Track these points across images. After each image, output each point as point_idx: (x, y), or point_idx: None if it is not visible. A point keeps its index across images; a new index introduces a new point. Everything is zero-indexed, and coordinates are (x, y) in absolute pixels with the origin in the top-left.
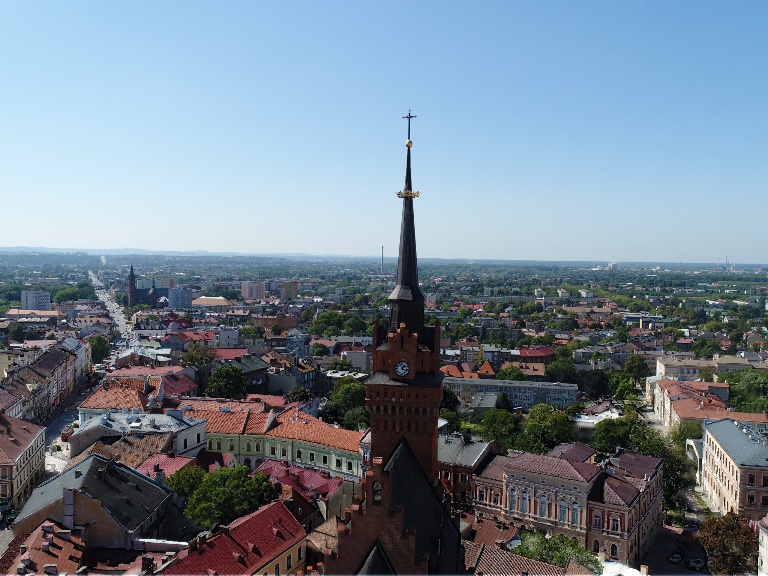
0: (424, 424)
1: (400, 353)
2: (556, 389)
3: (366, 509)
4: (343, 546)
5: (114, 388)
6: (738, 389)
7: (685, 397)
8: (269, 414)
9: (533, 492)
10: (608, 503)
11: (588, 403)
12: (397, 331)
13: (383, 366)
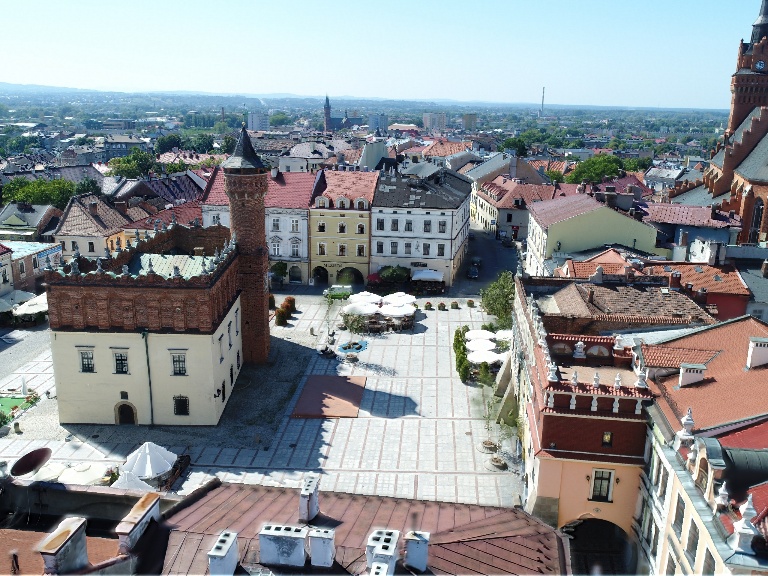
0: None
1: (760, 55)
2: None
3: None
4: (754, 127)
5: (448, 143)
6: None
7: None
8: (565, 162)
9: None
10: None
11: None
12: (760, 42)
13: (747, 64)
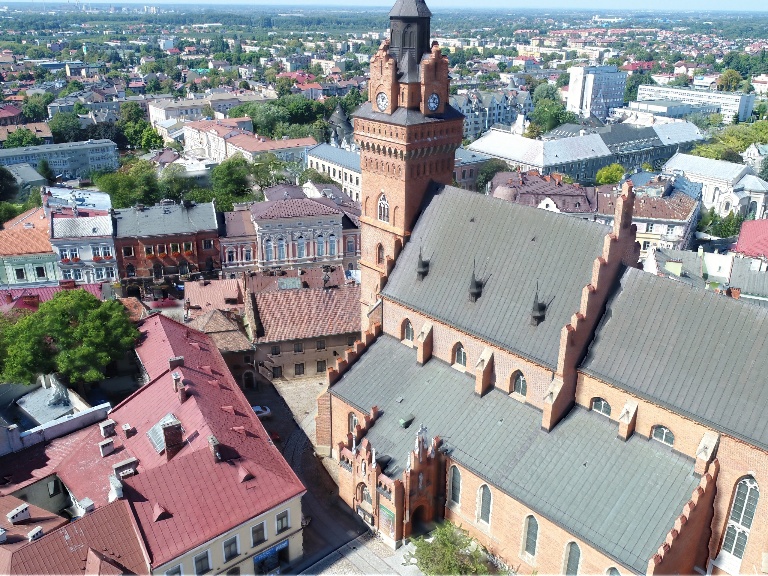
0: (448, 161)
1: (434, 83)
2: (93, 148)
3: (619, 235)
4: (601, 278)
5: None
6: (259, 121)
7: (236, 134)
8: None
9: (291, 237)
10: None
11: (147, 155)
12: (432, 56)
13: (412, 102)
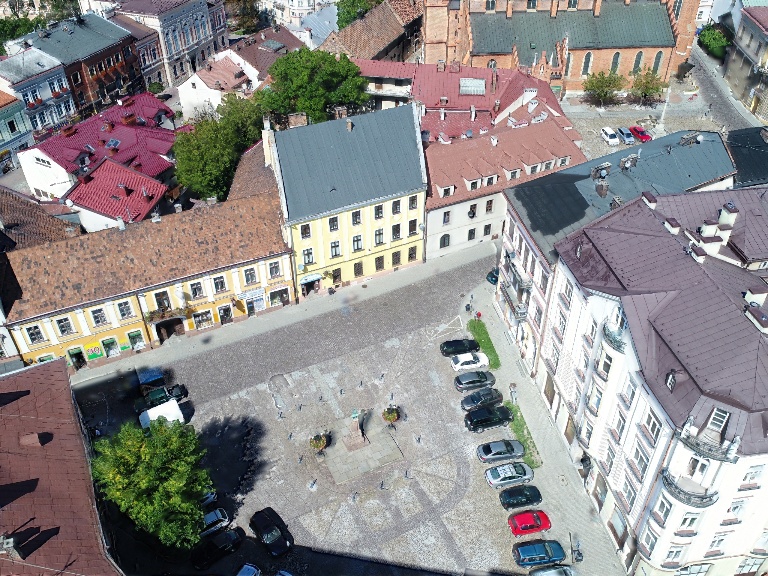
0: None
1: None
2: None
3: None
4: None
5: None
6: None
7: None
8: None
9: None
10: (215, 4)
11: None
12: None
13: None
